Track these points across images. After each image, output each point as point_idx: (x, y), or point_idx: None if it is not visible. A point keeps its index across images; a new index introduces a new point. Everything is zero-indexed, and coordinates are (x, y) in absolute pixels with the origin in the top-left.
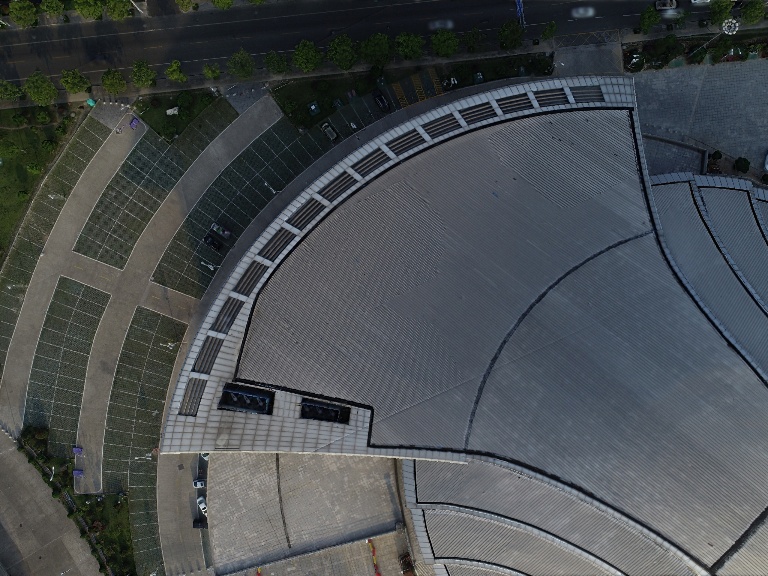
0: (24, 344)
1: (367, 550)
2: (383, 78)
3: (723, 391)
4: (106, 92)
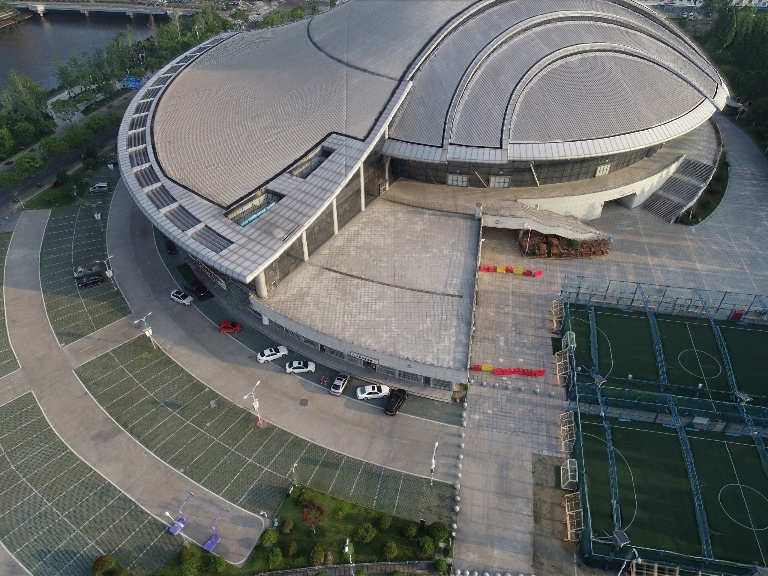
0: None
1: (505, 276)
2: None
3: None
4: None
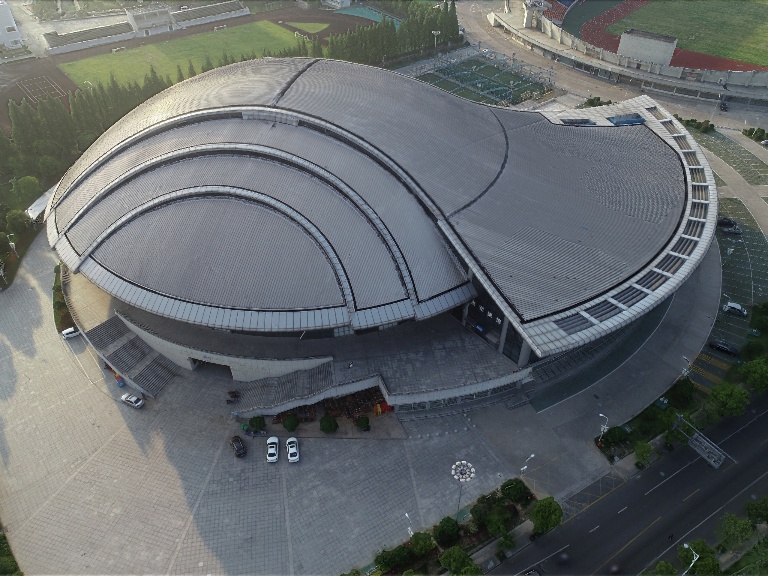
0: (765, 156)
1: None
2: None
3: (357, 113)
4: None
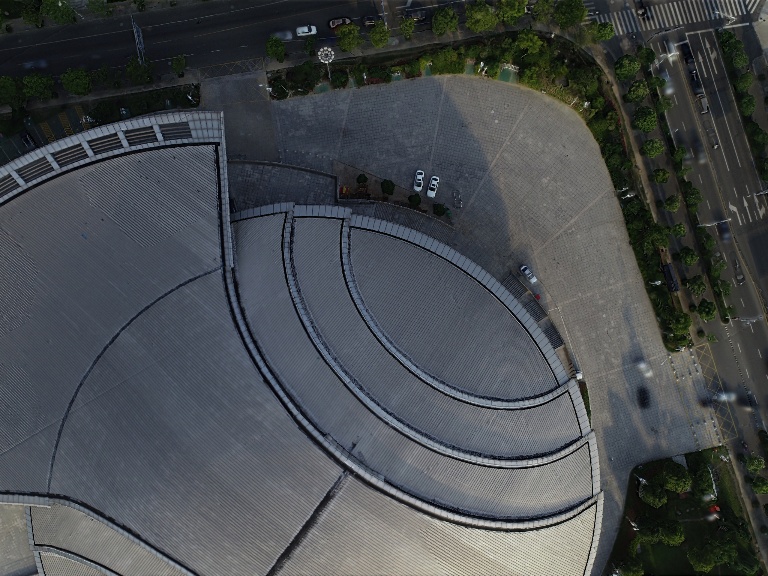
0: None
1: None
2: (30, 118)
3: (253, 428)
4: None
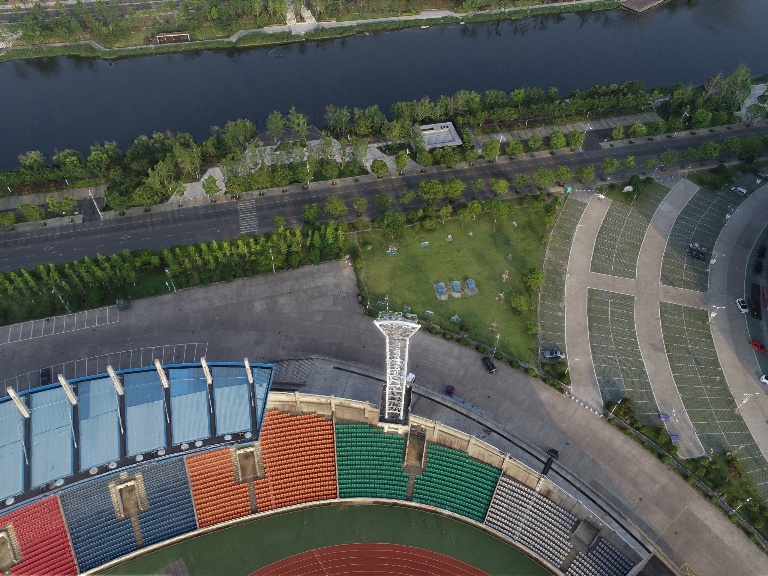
0: (577, 337)
1: None
2: (753, 166)
3: None
4: (574, 186)
